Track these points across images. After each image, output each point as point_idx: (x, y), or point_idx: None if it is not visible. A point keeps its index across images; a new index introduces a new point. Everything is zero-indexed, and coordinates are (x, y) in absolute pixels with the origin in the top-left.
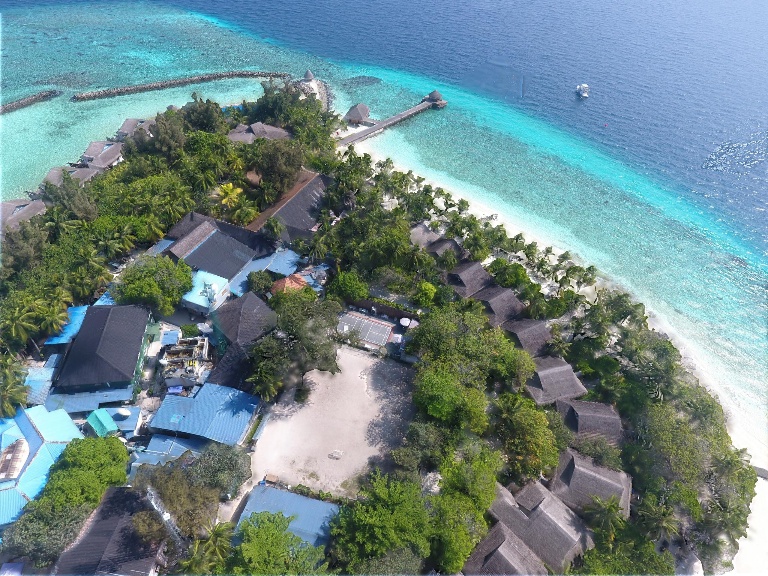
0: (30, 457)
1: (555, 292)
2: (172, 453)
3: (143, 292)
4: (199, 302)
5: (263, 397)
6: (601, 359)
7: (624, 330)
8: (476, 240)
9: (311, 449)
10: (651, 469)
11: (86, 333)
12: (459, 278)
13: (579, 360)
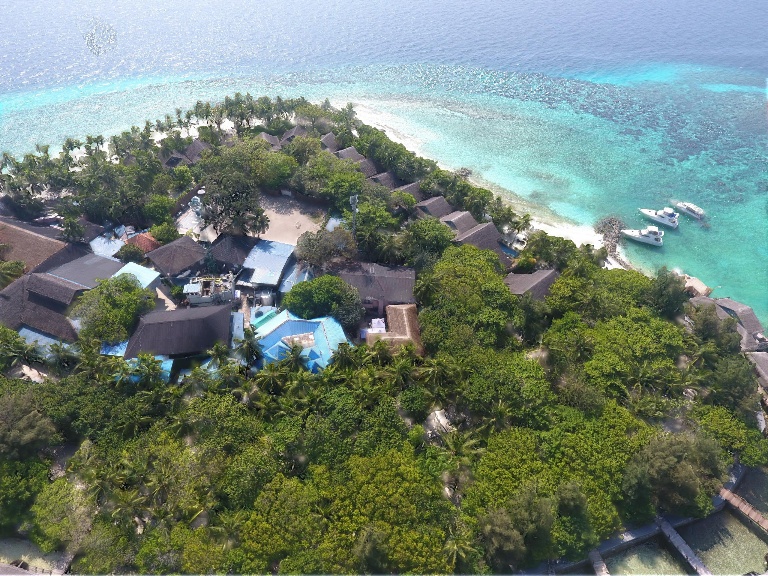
0: (297, 330)
1: (193, 137)
2: (293, 281)
3: (136, 300)
4: (152, 278)
5: (267, 227)
6: (256, 128)
7: (249, 106)
8: (145, 138)
9: (293, 235)
10: (323, 125)
11: (169, 342)
12: (173, 159)
13: (255, 135)
